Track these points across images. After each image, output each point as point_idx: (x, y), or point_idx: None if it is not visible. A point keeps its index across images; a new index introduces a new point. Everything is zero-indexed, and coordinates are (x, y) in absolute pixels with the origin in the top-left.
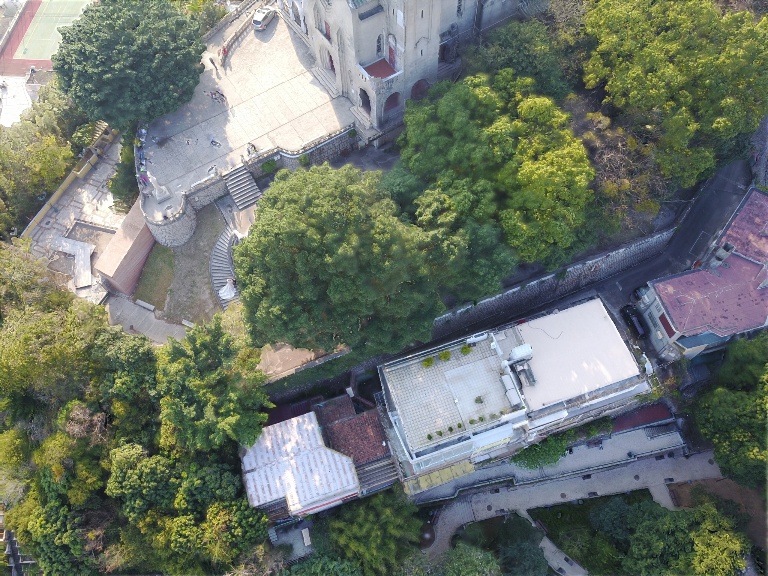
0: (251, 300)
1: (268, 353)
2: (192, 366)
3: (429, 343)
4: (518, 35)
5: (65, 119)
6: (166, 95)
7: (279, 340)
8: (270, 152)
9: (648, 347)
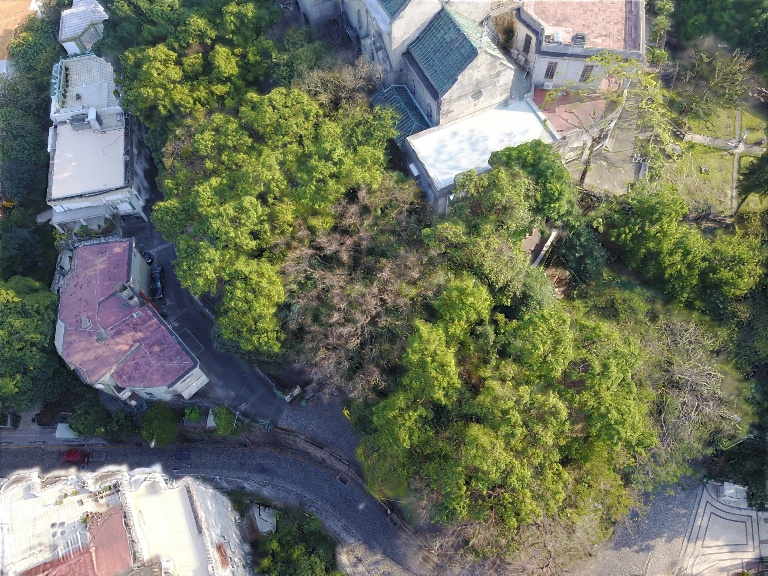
0: None
1: None
2: None
3: None
4: None
5: None
6: None
7: None
8: None
9: None
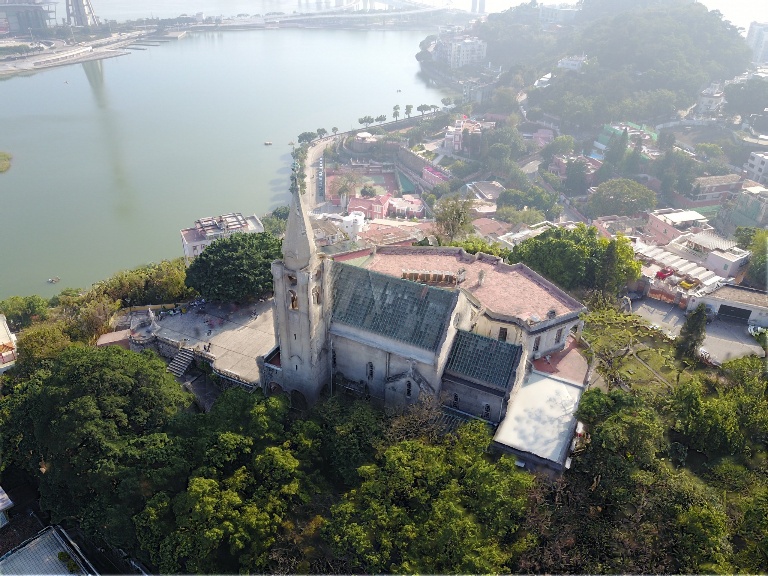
0: None
1: None
2: None
3: None
4: None
5: None
6: None
7: None
8: (210, 357)
9: None
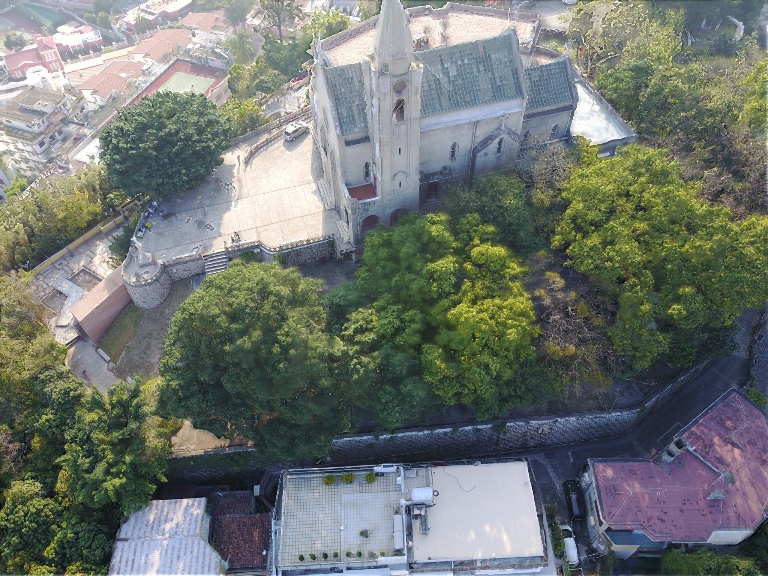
0: (165, 370)
1: (188, 428)
2: (103, 420)
3: (353, 462)
4: (495, 187)
5: (108, 181)
6: (177, 177)
7: (172, 414)
8: (251, 244)
9: (583, 532)
